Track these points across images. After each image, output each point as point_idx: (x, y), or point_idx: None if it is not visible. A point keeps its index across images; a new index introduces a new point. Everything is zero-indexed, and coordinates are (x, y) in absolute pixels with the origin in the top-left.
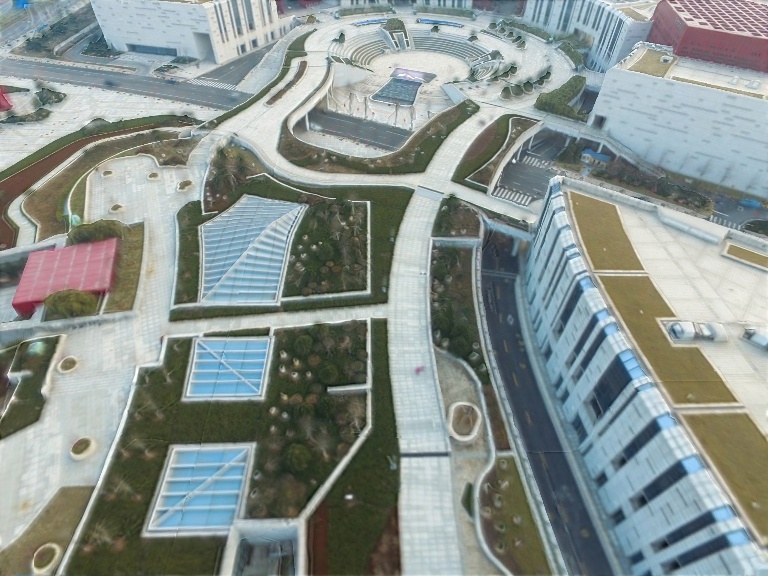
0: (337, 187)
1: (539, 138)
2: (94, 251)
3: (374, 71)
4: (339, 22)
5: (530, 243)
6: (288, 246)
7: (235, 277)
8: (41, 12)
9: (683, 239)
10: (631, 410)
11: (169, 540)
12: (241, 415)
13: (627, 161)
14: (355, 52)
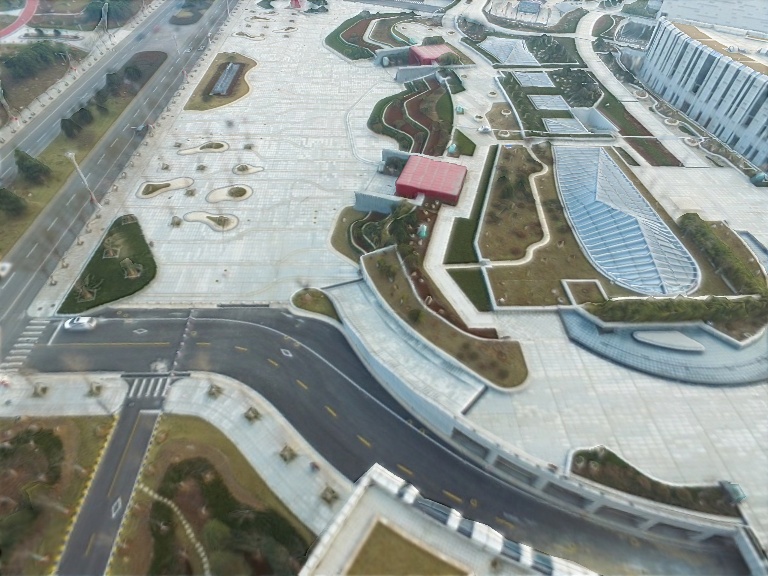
0: (533, 36)
1: (626, 29)
2: (439, 47)
3: None
4: None
5: (643, 59)
6: (528, 51)
7: (514, 57)
8: None
9: (727, 35)
10: (716, 69)
11: None
12: (550, 89)
13: None
14: None
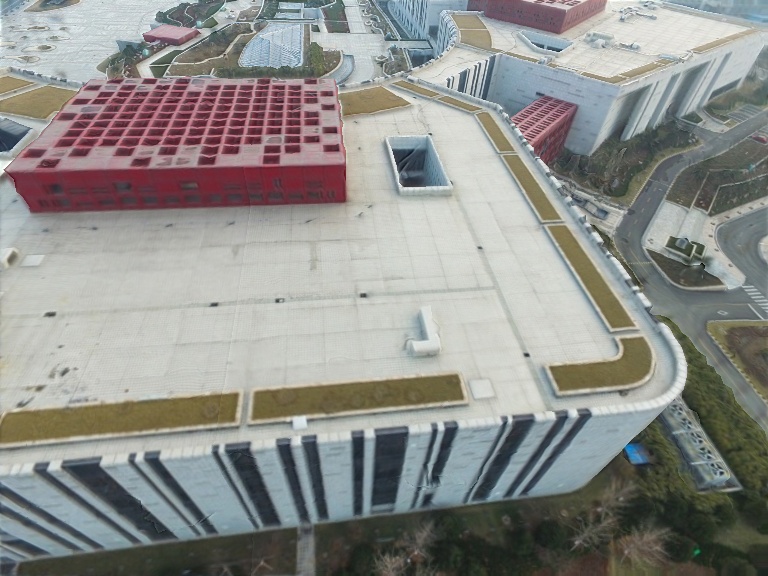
0: None
1: None
2: None
3: None
4: None
5: None
6: None
7: None
8: None
9: None
10: None
11: None
12: None
13: None
14: None
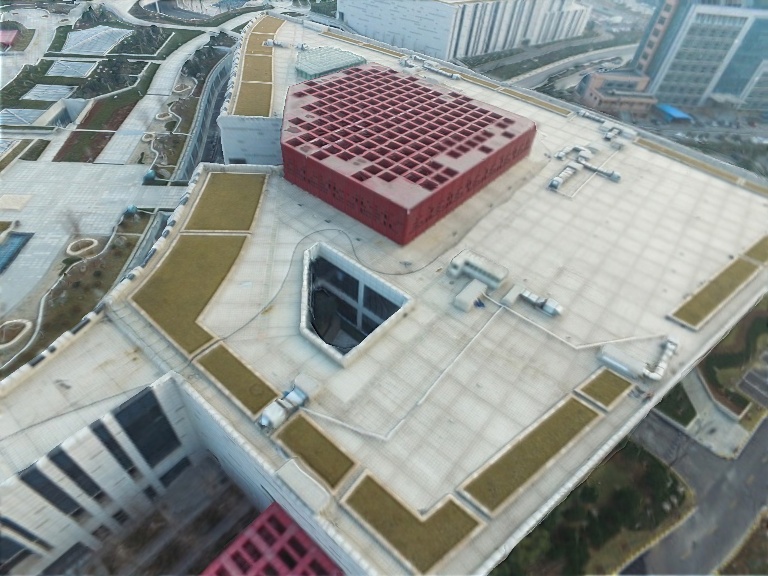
0: None
1: None
2: (4, 33)
3: None
4: None
5: None
6: (118, 41)
7: (83, 46)
8: None
9: (307, 30)
10: None
11: (32, 100)
12: (73, 79)
13: None
14: None
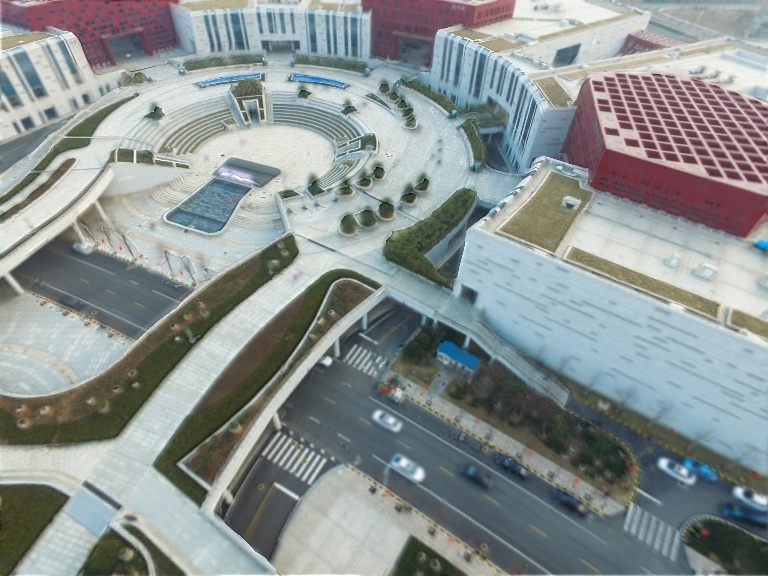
0: None
1: (383, 308)
2: None
3: (195, 164)
4: (180, 80)
5: None
6: None
7: None
8: None
9: None
10: None
11: None
12: None
13: (507, 368)
14: (177, 132)
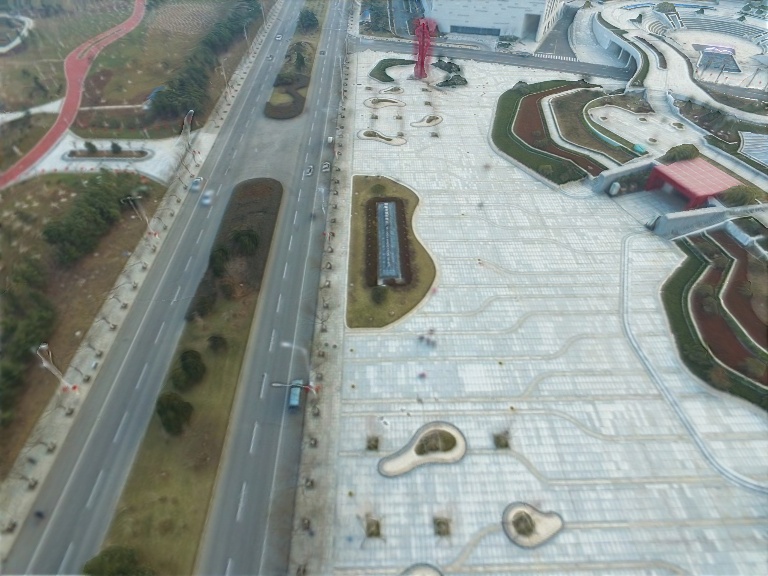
0: None
1: None
2: (699, 165)
3: None
4: (607, 6)
5: None
6: None
7: None
8: (351, 0)
9: None
10: None
11: None
12: None
13: None
14: None
